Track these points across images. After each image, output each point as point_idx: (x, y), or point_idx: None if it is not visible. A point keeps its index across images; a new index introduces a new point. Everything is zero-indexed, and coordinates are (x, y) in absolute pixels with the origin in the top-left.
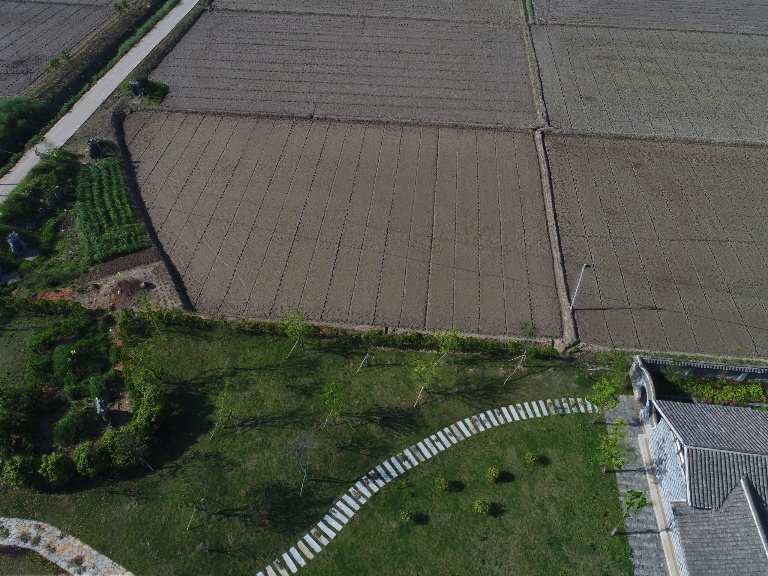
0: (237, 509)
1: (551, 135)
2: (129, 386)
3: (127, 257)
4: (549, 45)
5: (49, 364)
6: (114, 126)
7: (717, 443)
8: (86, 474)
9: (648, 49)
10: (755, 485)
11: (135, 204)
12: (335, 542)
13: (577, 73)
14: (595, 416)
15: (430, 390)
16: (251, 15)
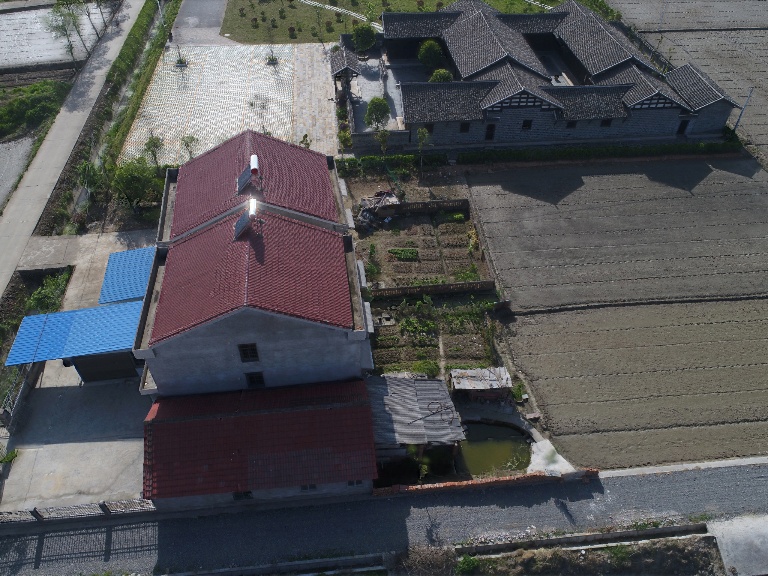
0: None
1: None
2: None
3: None
4: None
5: None
6: None
7: None
8: None
9: None
10: None
11: None
12: None
13: None
14: None
15: None
16: None
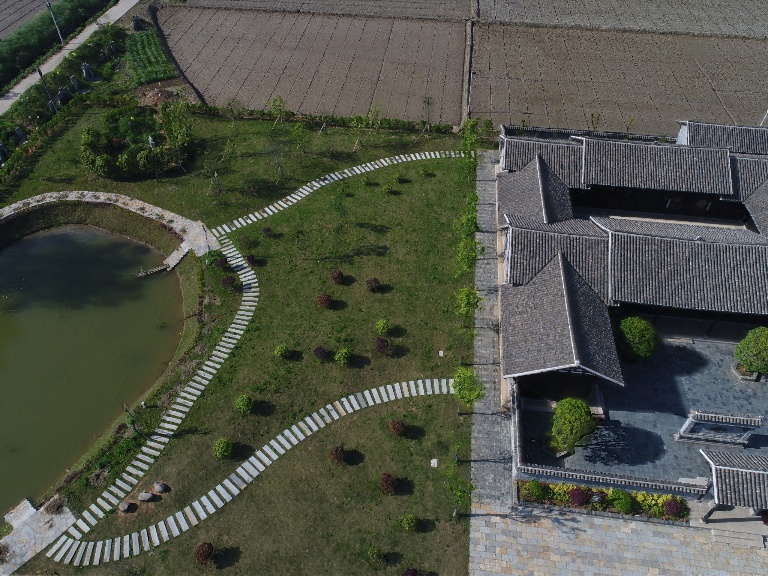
0: (237, 188)
1: (479, 24)
2: (169, 135)
3: (164, 81)
4: None
5: (116, 127)
6: (150, 14)
7: None
8: (145, 169)
9: None
10: (544, 158)
11: (168, 55)
12: (296, 204)
13: None
14: None
15: (364, 144)
16: None
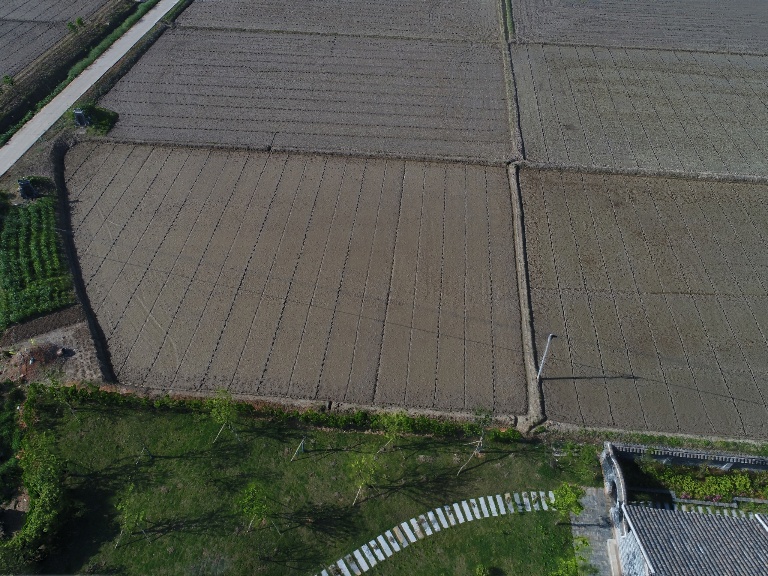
0: None
1: (526, 169)
2: (26, 483)
3: (47, 317)
4: (529, 66)
5: None
6: (53, 160)
7: (693, 572)
8: None
9: (634, 71)
10: None
11: (64, 253)
12: None
13: (557, 98)
14: (559, 516)
15: (373, 483)
16: (215, 33)
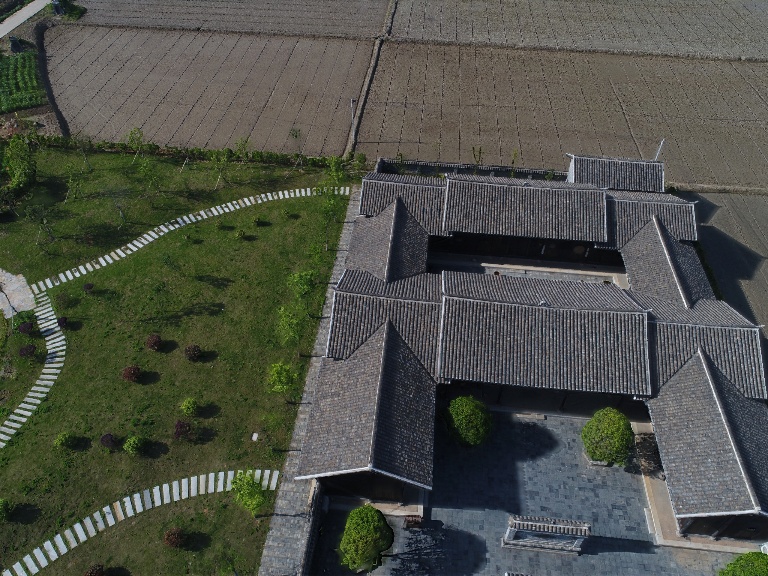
0: (73, 235)
1: (389, 42)
2: (11, 173)
3: (28, 110)
4: None
5: None
6: (36, 33)
7: None
8: None
9: None
10: (405, 202)
11: (41, 80)
12: (136, 252)
13: (429, 2)
14: None
15: (229, 181)
16: None
